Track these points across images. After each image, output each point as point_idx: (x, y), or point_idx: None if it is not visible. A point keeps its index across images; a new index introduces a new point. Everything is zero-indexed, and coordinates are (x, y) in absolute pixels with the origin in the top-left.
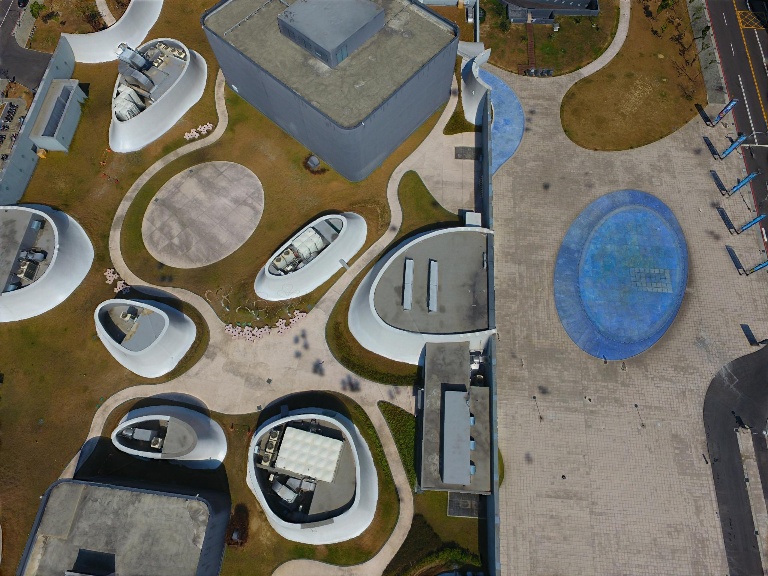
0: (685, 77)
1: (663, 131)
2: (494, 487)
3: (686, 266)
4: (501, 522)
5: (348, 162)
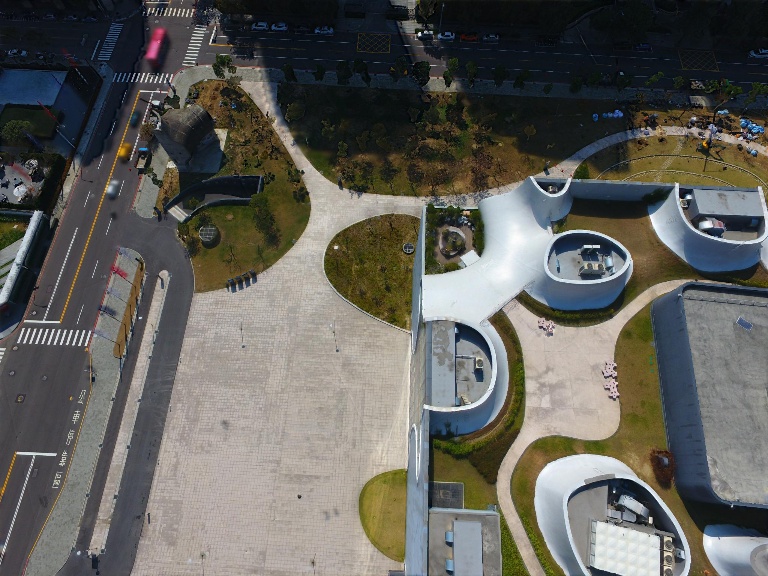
0: None
1: None
2: None
3: None
4: (366, 452)
5: None
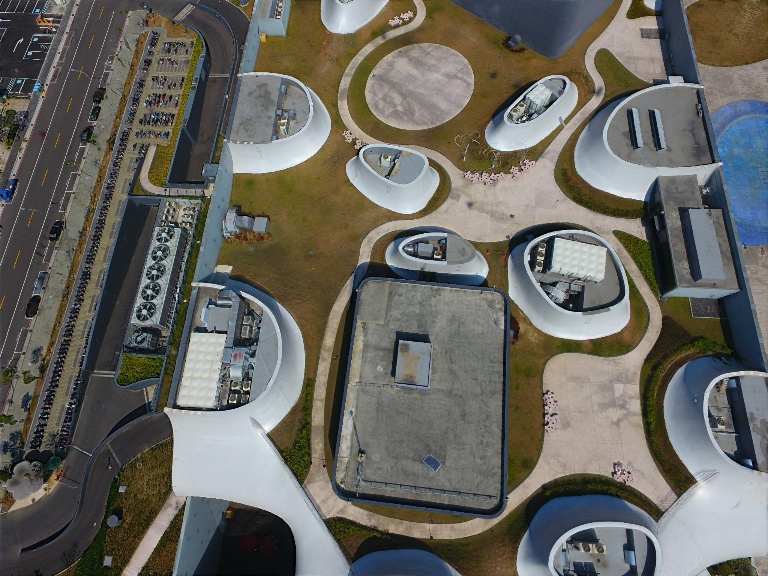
0: None
1: None
2: (745, 282)
3: None
4: None
5: (558, 34)
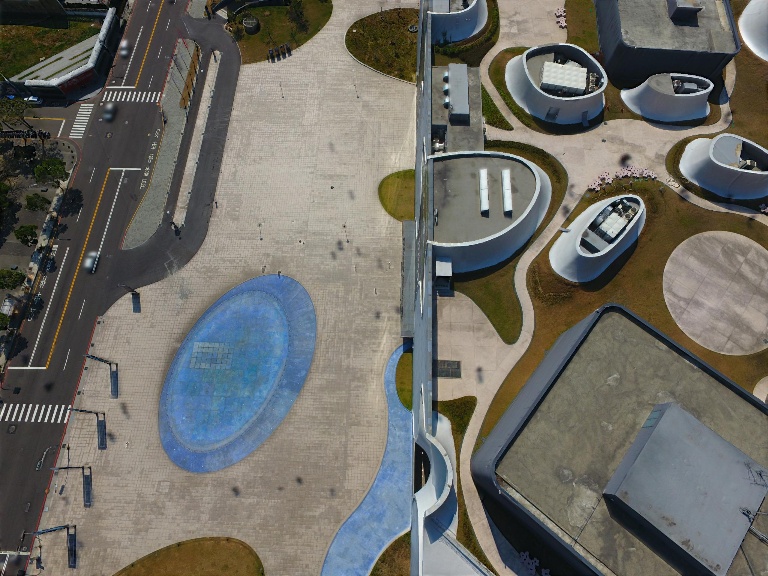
0: None
1: None
2: None
3: (170, 372)
4: (383, 160)
5: None
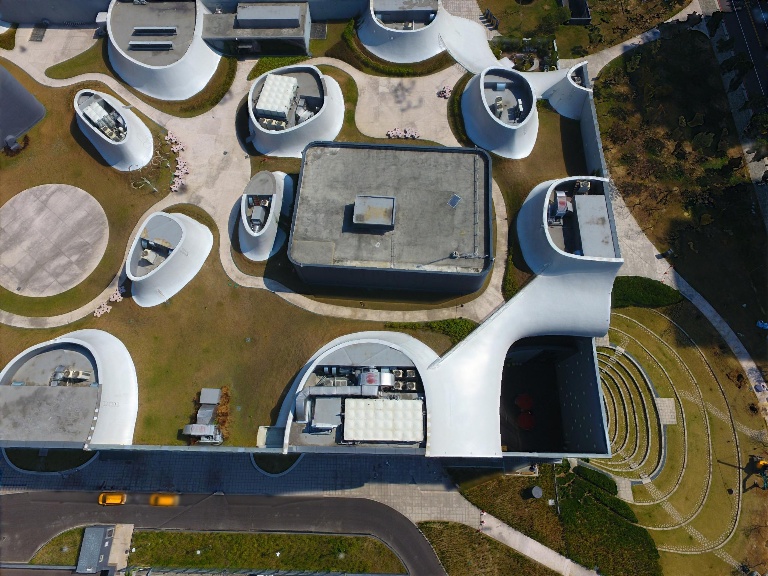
0: None
1: None
2: None
3: None
4: None
5: (20, 96)
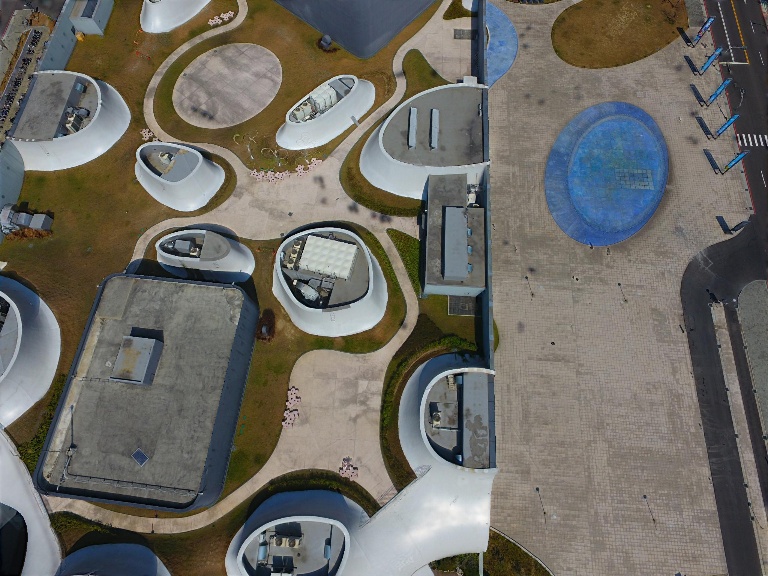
0: (668, 4)
1: (647, 51)
2: (488, 280)
3: (667, 167)
4: (496, 381)
5: (358, 34)
